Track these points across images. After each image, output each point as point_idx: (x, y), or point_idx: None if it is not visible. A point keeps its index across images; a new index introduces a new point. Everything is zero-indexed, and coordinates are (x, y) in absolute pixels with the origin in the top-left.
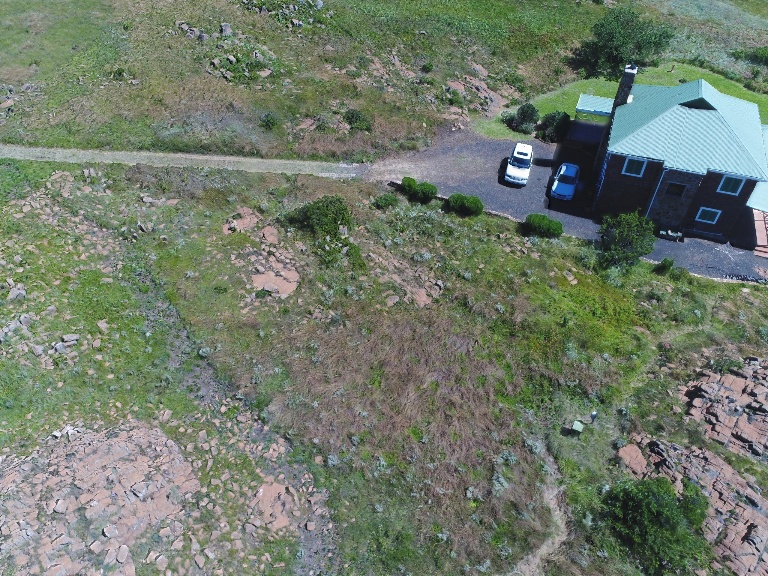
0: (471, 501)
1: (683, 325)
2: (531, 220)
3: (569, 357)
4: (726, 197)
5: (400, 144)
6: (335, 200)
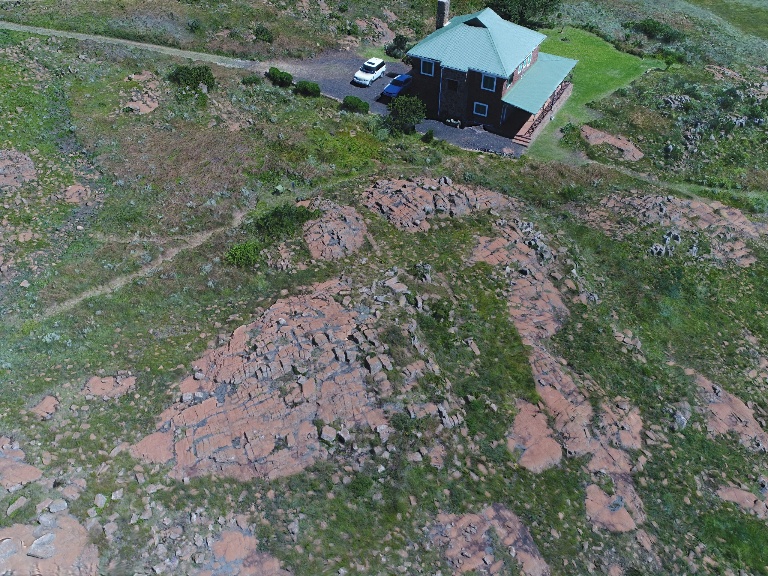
0: (190, 209)
1: (412, 165)
2: (346, 99)
3: (307, 163)
4: (488, 93)
5: (288, 52)
6: (202, 67)
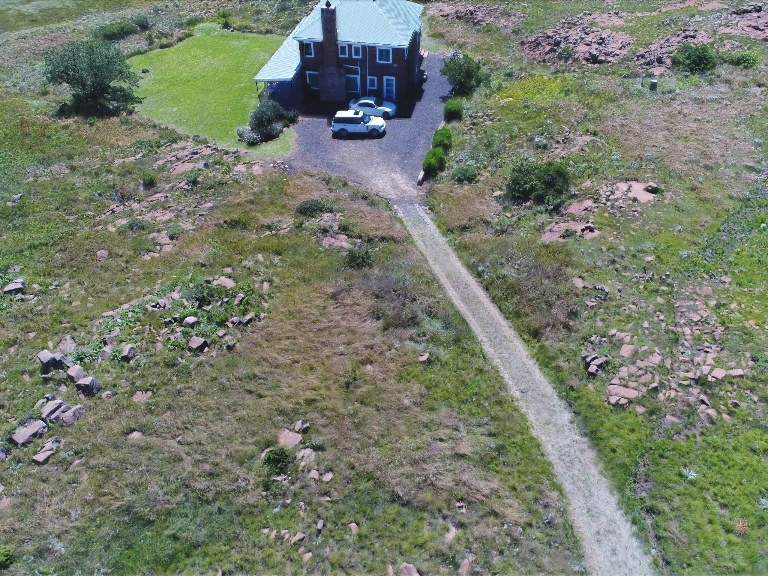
0: None
1: None
2: (457, 108)
3: None
4: None
5: (345, 183)
6: (526, 164)
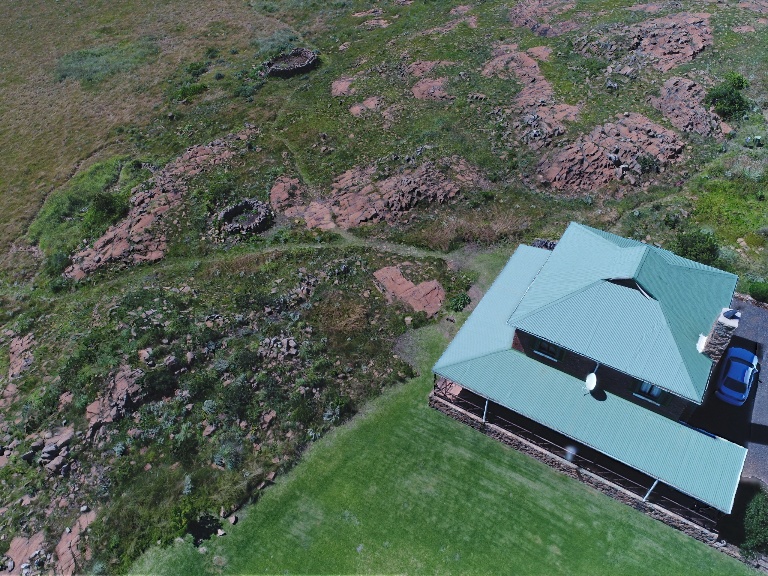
0: None
1: None
2: None
3: None
4: None
5: None
6: None
